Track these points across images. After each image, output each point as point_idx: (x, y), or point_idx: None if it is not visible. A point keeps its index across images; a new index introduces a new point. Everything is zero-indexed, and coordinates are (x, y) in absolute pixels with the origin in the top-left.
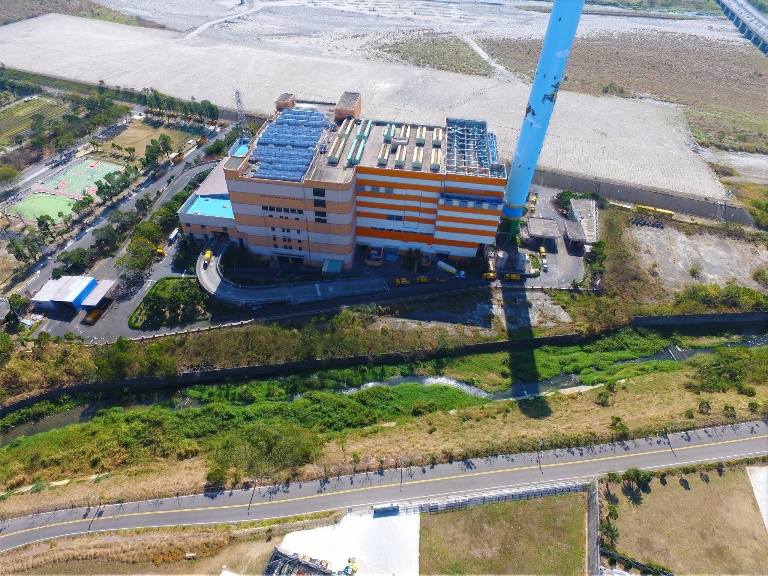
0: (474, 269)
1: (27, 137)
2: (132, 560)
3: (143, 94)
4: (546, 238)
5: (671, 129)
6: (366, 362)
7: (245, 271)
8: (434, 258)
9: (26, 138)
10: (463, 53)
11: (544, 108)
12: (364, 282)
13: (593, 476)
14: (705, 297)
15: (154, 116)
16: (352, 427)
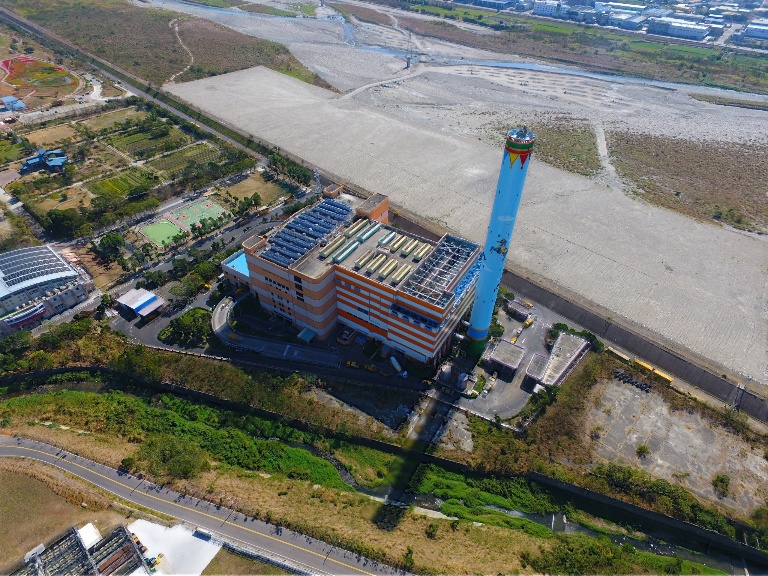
0: (420, 373)
1: (181, 175)
2: (57, 492)
3: (273, 151)
4: (505, 365)
5: (765, 280)
6: (284, 421)
7: (251, 318)
8: (393, 352)
9: (180, 176)
10: (580, 146)
11: (493, 257)
12: (325, 355)
13: None
14: (622, 480)
15: (271, 170)
16: (241, 466)
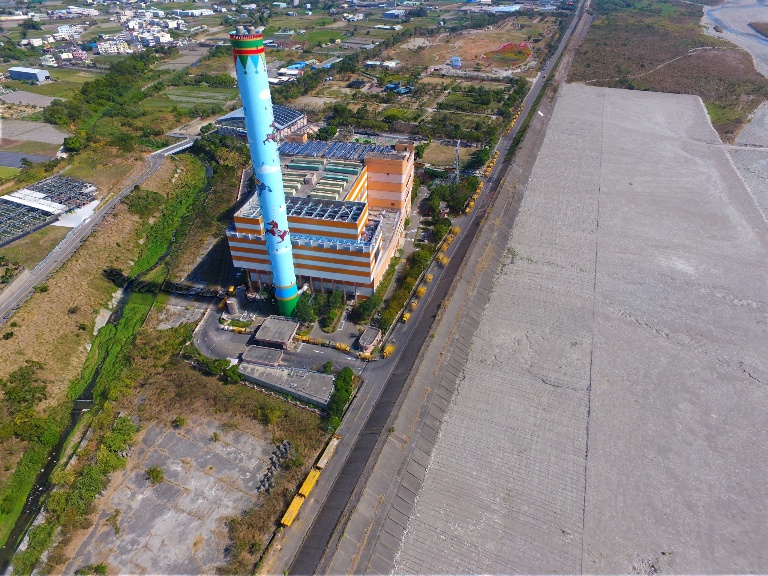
0: None
1: (432, 124)
2: None
3: None
4: None
5: None
6: None
7: None
8: None
9: (431, 124)
10: None
11: None
12: None
13: (34, 277)
14: None
15: None
16: None
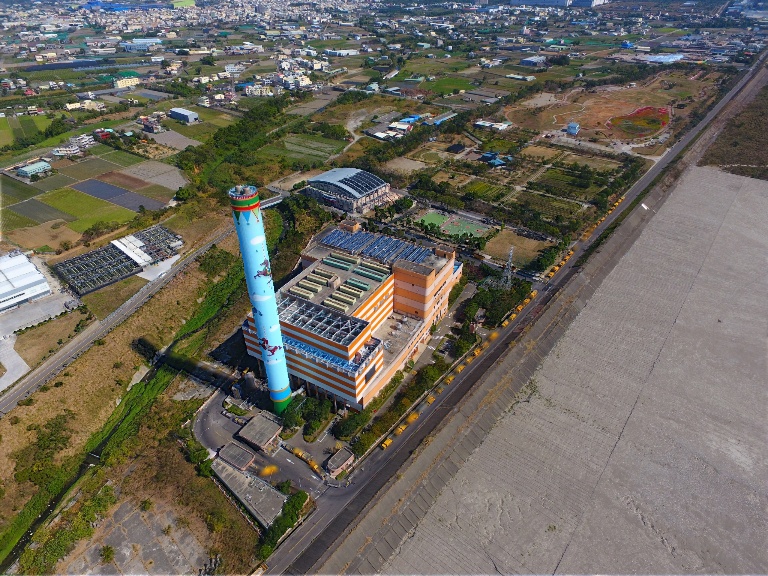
0: None
1: None
2: None
3: None
4: None
5: None
6: None
7: None
8: None
9: None
10: None
11: None
12: None
13: (101, 327)
14: None
15: None
16: None
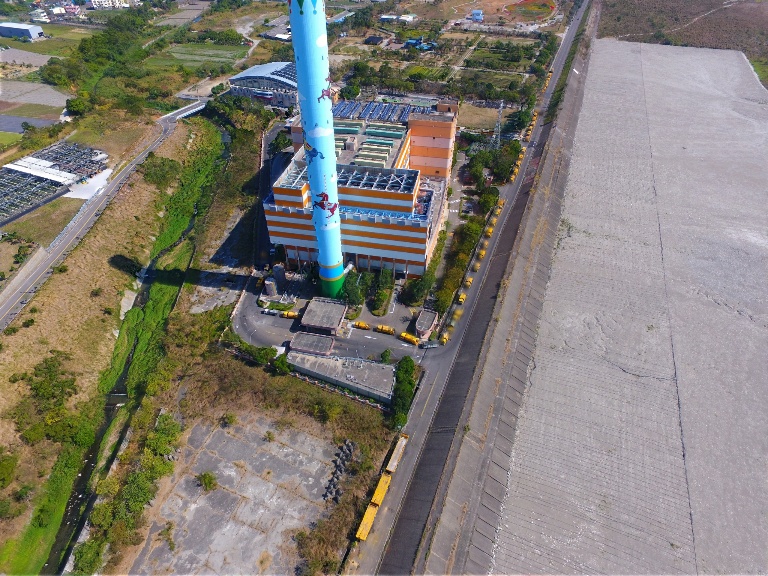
0: None
1: (461, 83)
2: None
3: None
4: None
5: None
6: None
7: None
8: None
9: (460, 83)
10: None
11: None
12: None
13: (49, 255)
14: None
15: None
16: None
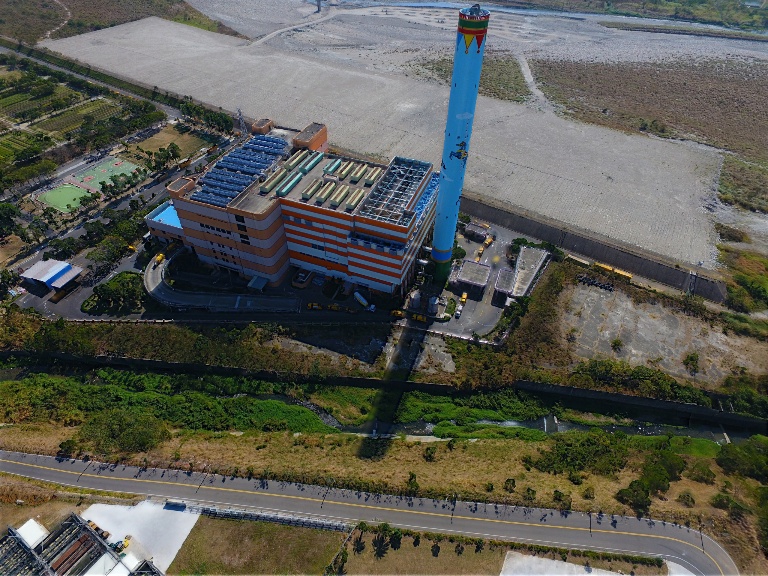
0: (388, 305)
1: (78, 134)
2: None
3: (184, 101)
4: (473, 284)
5: (694, 180)
6: (248, 374)
7: (190, 275)
8: (356, 288)
9: (77, 135)
10: (507, 75)
11: (453, 164)
12: (282, 301)
13: (365, 521)
14: (604, 373)
15: (186, 122)
16: (207, 429)
